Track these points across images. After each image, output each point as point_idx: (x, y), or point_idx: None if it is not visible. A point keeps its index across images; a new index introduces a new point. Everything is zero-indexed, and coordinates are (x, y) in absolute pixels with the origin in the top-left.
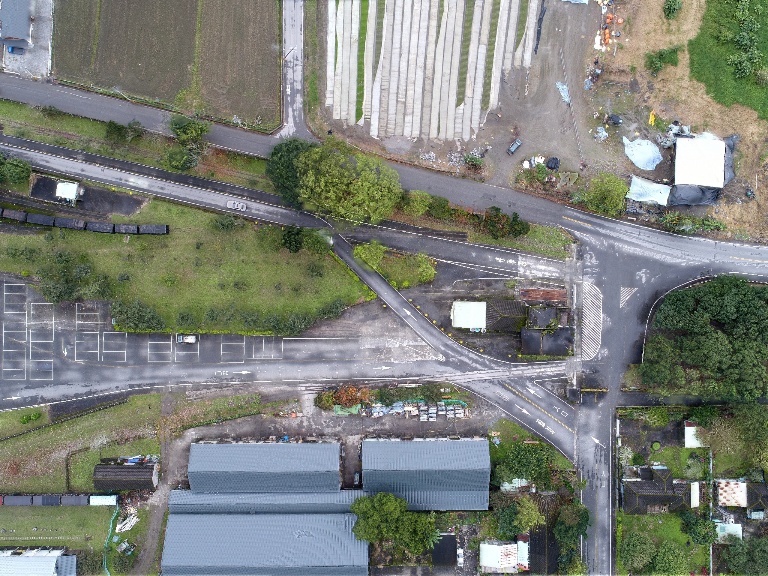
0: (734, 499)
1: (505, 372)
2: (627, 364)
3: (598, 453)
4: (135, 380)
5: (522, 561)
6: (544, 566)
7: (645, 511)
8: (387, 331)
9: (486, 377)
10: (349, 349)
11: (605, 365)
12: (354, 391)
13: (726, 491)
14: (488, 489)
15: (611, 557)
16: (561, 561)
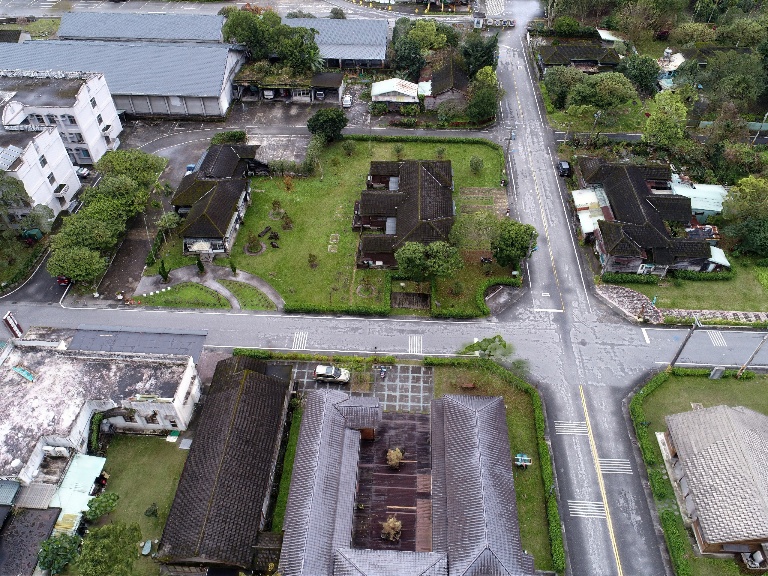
0: (672, 65)
1: (412, 18)
2: (531, 17)
3: (511, 53)
4: (52, 13)
5: (423, 93)
6: (449, 82)
7: (567, 60)
8: (303, 2)
9: (393, 20)
10: (264, 7)
11: (510, 17)
12: (260, 8)
13: (661, 63)
14: (385, 44)
15: (539, 109)
16: (471, 84)
